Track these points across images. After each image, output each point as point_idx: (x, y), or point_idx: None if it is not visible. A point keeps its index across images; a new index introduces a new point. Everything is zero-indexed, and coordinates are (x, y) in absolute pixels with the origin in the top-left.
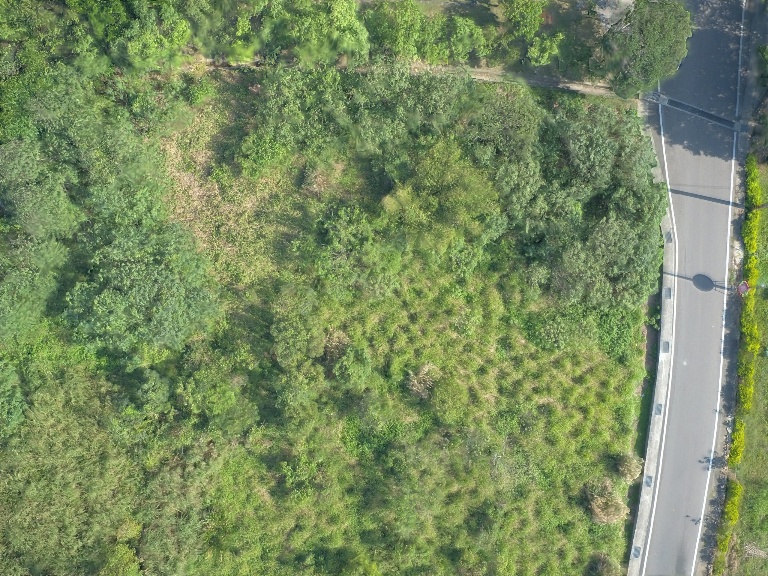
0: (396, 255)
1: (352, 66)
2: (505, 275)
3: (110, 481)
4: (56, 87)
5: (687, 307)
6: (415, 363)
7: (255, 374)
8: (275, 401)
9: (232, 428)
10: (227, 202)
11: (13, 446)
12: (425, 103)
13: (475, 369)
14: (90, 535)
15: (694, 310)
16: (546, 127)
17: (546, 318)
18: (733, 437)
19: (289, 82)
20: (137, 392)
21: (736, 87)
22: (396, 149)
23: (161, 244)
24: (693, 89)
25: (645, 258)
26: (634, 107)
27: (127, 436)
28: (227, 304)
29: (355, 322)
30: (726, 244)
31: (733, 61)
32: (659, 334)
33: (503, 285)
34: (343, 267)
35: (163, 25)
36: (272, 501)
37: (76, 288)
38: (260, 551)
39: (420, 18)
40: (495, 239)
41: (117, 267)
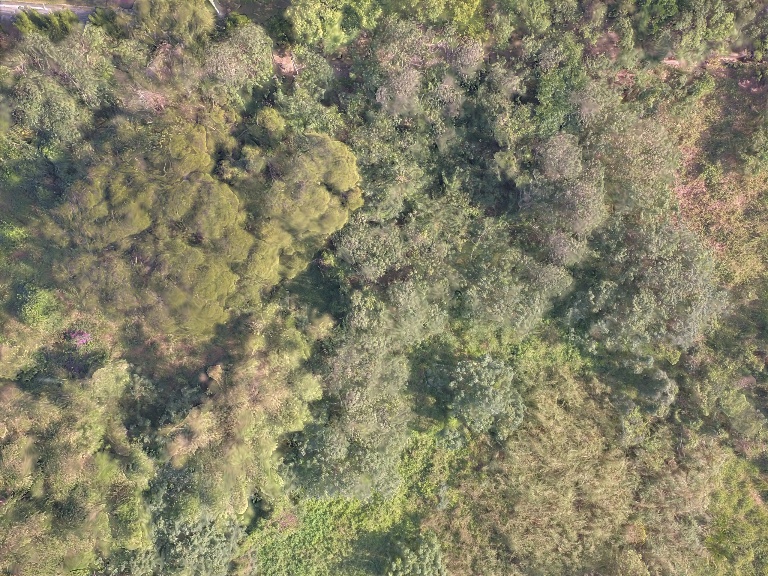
0: None
1: None
2: None
3: (612, 485)
4: (598, 81)
5: None
6: None
7: None
8: (767, 404)
9: (750, 432)
10: (716, 200)
11: (511, 449)
12: None
13: None
14: (591, 541)
15: None
16: None
17: None
18: None
19: None
20: (647, 394)
21: None
22: None
23: (682, 243)
24: None
25: None
26: None
27: (627, 439)
28: None
29: None
30: None
31: None
32: None
33: None
34: None
35: (713, 18)
36: (763, 506)
37: (602, 287)
38: (752, 557)
39: None
40: None
41: (653, 266)
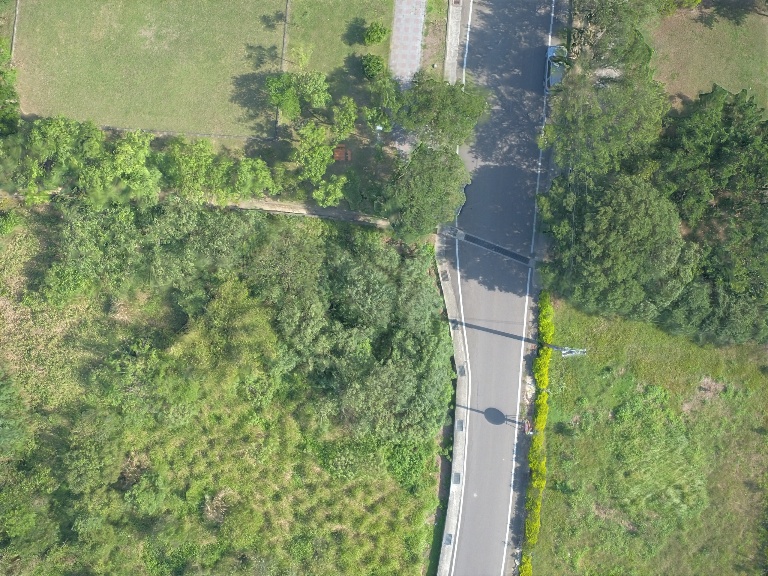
0: (192, 385)
1: (145, 206)
2: (302, 404)
3: None
4: None
5: (478, 440)
6: (213, 487)
7: (61, 493)
8: None
9: (27, 551)
10: (38, 327)
11: None
12: (210, 245)
13: (270, 495)
14: None
15: (485, 443)
16: (335, 266)
17: (340, 447)
18: (520, 569)
19: (82, 223)
20: None
21: (532, 224)
22: (191, 284)
23: None
24: (490, 225)
25: (427, 397)
26: (432, 242)
27: None
28: (36, 425)
29: (156, 446)
30: (518, 379)
31: (529, 198)
32: (451, 465)
33: (298, 414)
34: (134, 399)
35: None
36: None
37: None
38: None
39: (205, 164)
40: (291, 370)
41: None
